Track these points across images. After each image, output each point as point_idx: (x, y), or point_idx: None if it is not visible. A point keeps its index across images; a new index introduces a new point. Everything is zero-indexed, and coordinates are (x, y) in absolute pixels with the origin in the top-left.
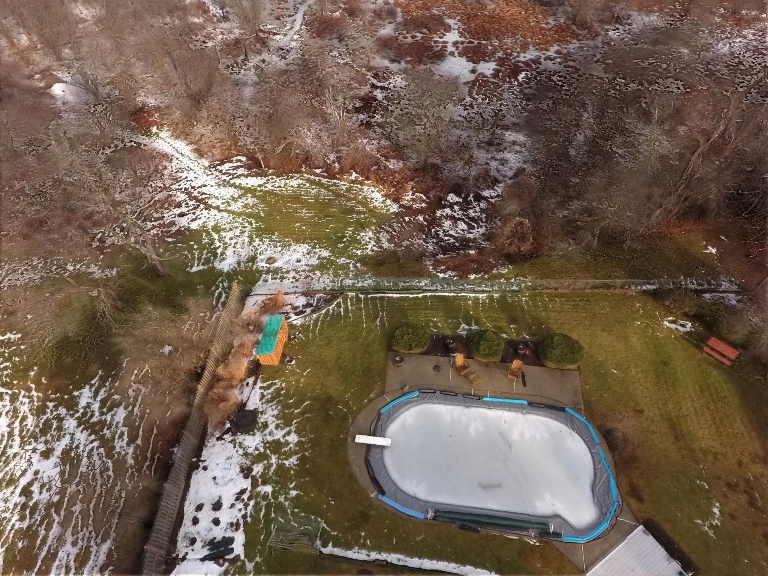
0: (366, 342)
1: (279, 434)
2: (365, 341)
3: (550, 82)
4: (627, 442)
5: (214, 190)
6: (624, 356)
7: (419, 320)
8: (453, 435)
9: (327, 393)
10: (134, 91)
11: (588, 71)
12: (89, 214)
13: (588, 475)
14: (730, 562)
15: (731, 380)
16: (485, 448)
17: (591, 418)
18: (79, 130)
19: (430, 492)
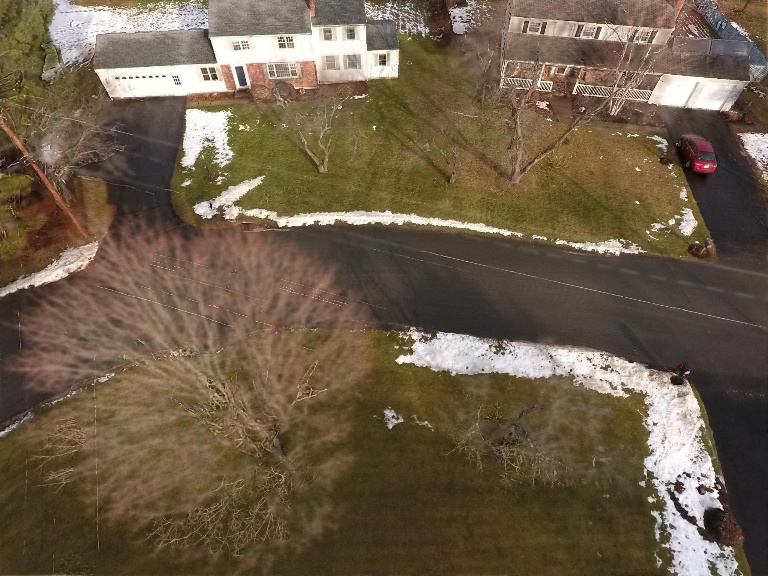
0: None
1: (478, 6)
2: None
3: None
4: None
5: None
6: None
7: None
8: None
9: None
10: None
11: None
12: None
13: None
14: None
15: None
16: None
17: None
18: None
19: None
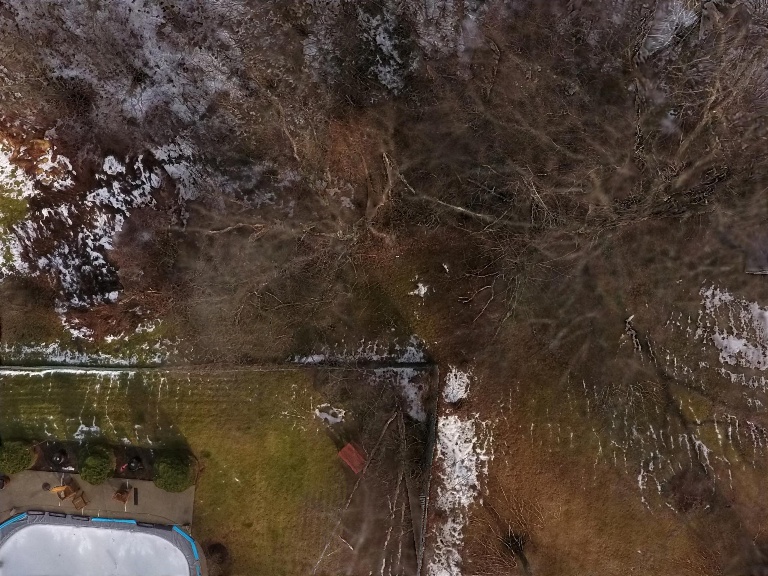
0: None
1: None
2: None
3: None
4: (225, 558)
5: None
6: (252, 461)
7: (32, 419)
8: (62, 554)
9: None
10: None
11: None
12: None
13: None
14: None
15: None
16: (92, 566)
17: (197, 535)
18: None
19: None
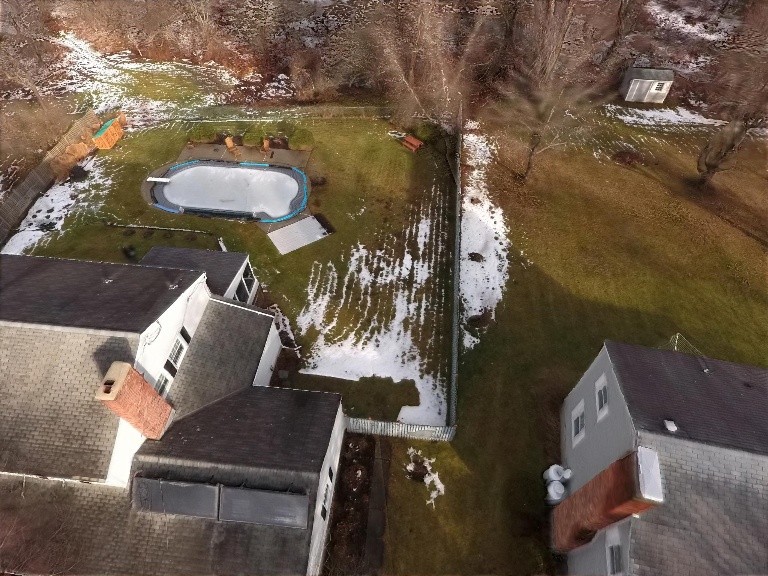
0: (174, 139)
1: (100, 181)
2: (174, 138)
3: (392, 7)
4: (324, 182)
5: (101, 70)
6: (348, 147)
7: (217, 130)
8: (214, 180)
9: (138, 161)
10: (51, 8)
11: (426, 0)
12: (0, 82)
13: (292, 196)
14: (356, 228)
15: (413, 158)
16: (232, 185)
17: (308, 173)
18: (1, 31)
19: (187, 203)
